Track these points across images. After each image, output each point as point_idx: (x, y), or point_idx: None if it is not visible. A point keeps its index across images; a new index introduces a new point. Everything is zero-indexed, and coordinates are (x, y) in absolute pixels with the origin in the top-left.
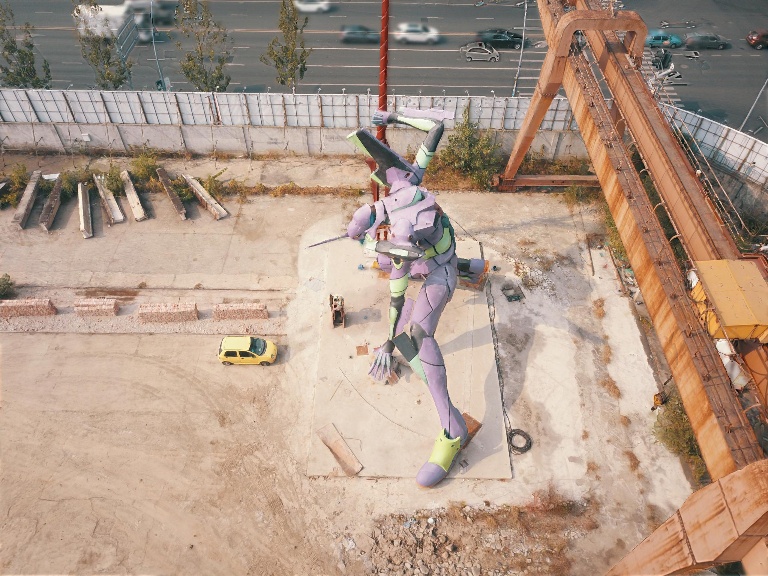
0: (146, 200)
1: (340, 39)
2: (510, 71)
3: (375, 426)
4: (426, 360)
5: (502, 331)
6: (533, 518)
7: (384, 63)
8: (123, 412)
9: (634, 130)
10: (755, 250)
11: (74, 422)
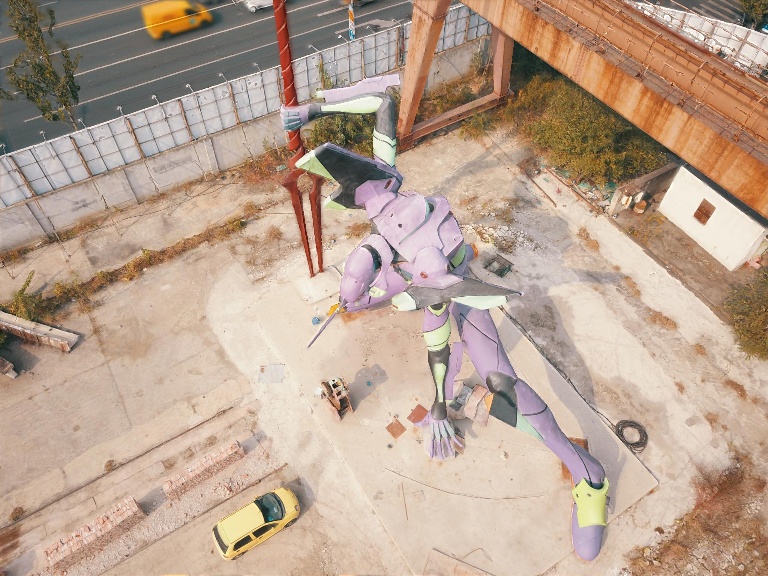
0: None
1: (70, 33)
2: (307, 9)
3: (482, 518)
4: (530, 412)
5: (520, 316)
6: (707, 515)
7: (285, 34)
8: None
9: None
10: None
11: None
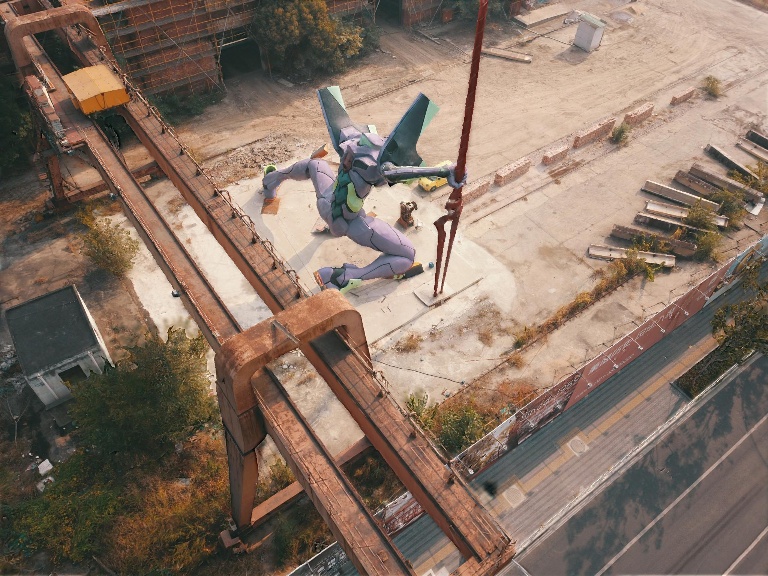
0: None
1: None
2: None
3: None
4: None
5: None
6: None
7: None
8: None
9: None
10: None
11: (482, 121)
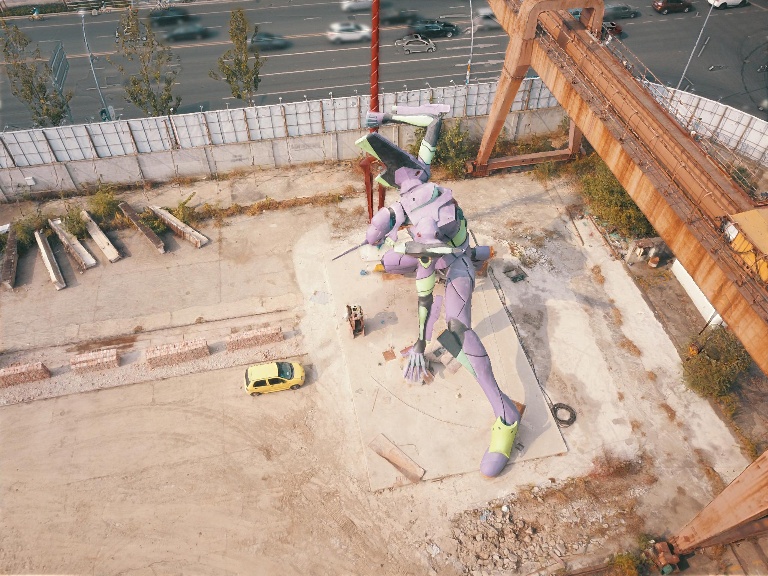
0: (115, 239)
1: (273, 46)
2: (449, 59)
3: (424, 428)
4: (471, 353)
5: (516, 312)
6: (597, 485)
7: (376, 64)
8: (158, 467)
9: (613, 101)
10: (765, 197)
11: (107, 488)
